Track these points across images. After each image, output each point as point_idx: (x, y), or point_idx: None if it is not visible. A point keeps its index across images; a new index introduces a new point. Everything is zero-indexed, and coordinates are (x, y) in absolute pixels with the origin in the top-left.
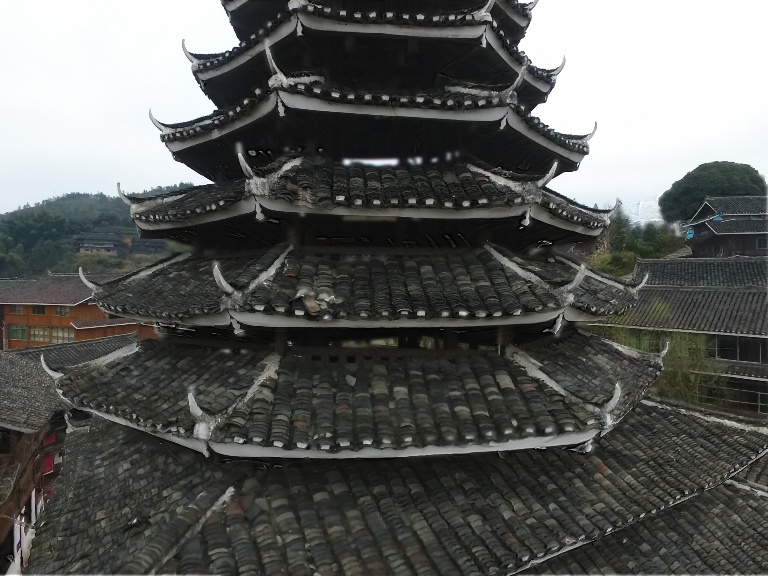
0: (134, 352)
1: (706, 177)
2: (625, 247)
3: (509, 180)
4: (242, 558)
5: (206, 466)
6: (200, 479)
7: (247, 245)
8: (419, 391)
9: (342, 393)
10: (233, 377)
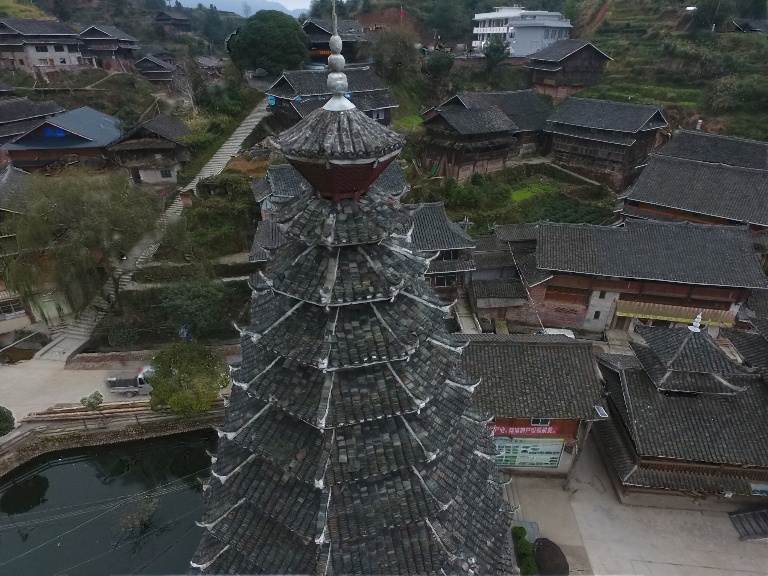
0: None
1: (268, 31)
2: (219, 110)
3: (483, 454)
4: None
5: None
6: None
7: None
8: None
9: None
10: None
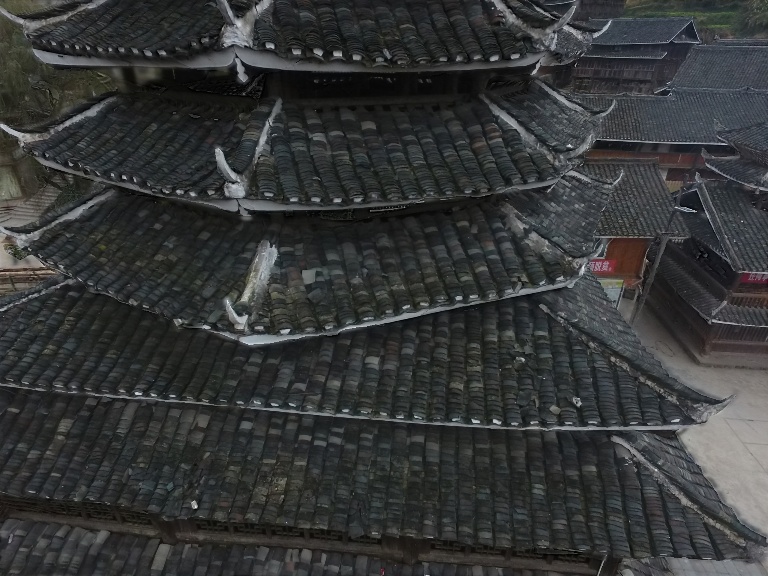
0: (282, 254)
1: None
2: None
3: (570, 27)
4: (600, 329)
5: (492, 309)
6: (511, 316)
7: (416, 91)
8: (559, 202)
9: (550, 217)
10: (503, 232)
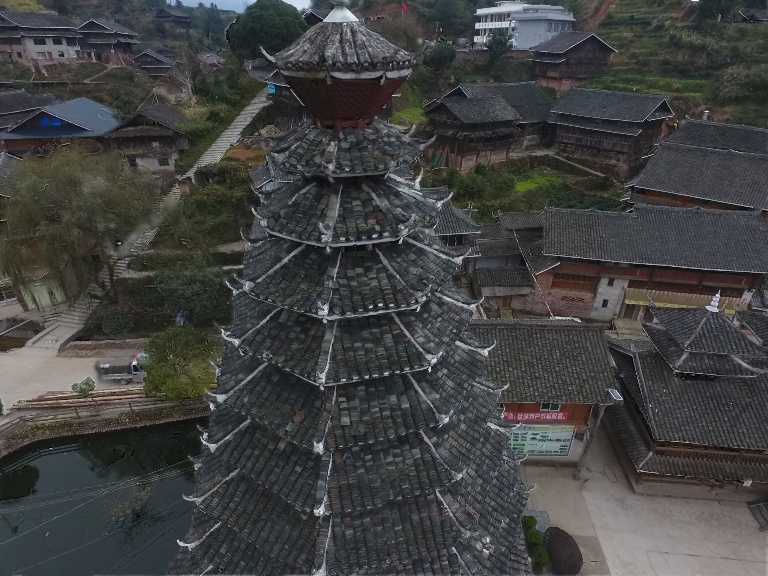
0: None
1: (268, 19)
2: (217, 99)
3: (497, 426)
4: None
5: None
6: None
7: None
8: None
9: None
10: None
